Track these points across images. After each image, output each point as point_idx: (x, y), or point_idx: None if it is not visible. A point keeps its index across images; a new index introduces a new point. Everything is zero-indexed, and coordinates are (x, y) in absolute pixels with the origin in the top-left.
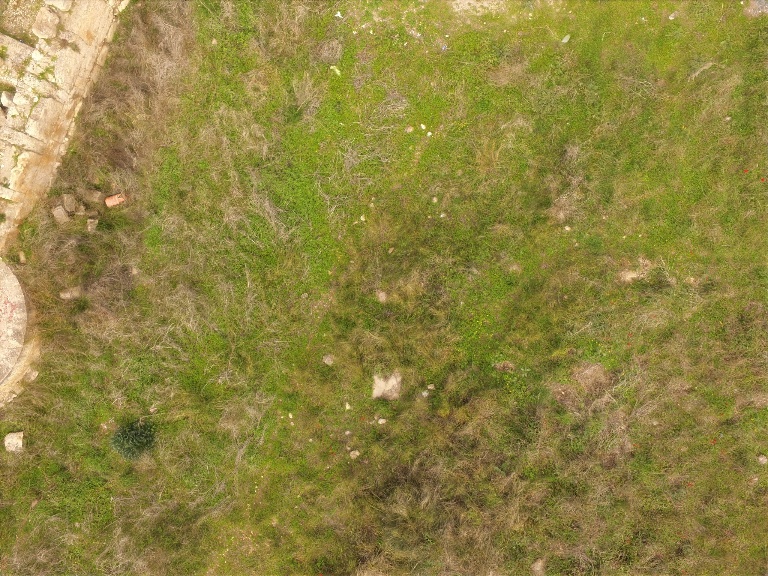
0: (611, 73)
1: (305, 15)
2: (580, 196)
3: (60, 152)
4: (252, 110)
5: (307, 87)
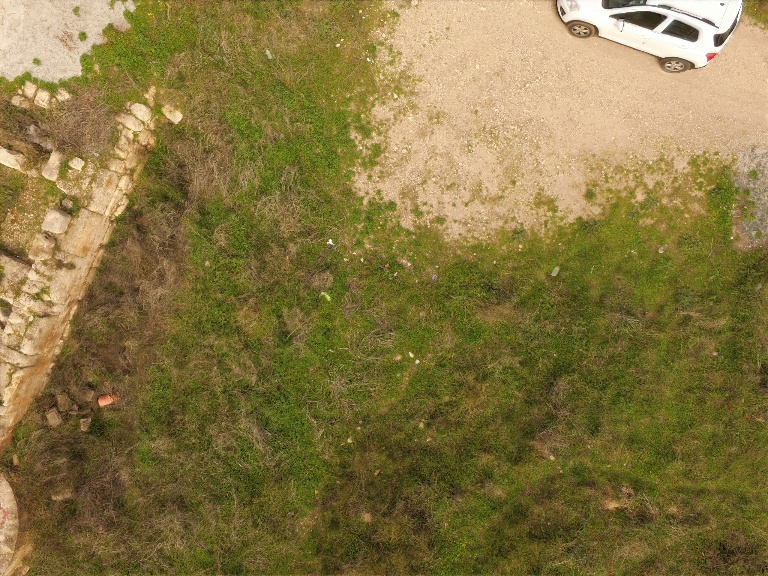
0: (599, 307)
1: (297, 248)
2: (565, 430)
3: (55, 353)
4: (243, 333)
5: (297, 318)
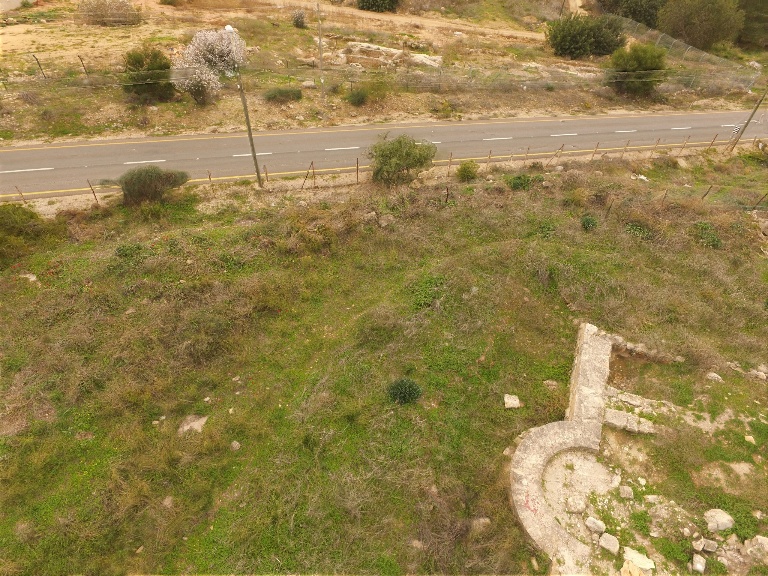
0: None
1: None
2: None
3: None
4: None
5: None
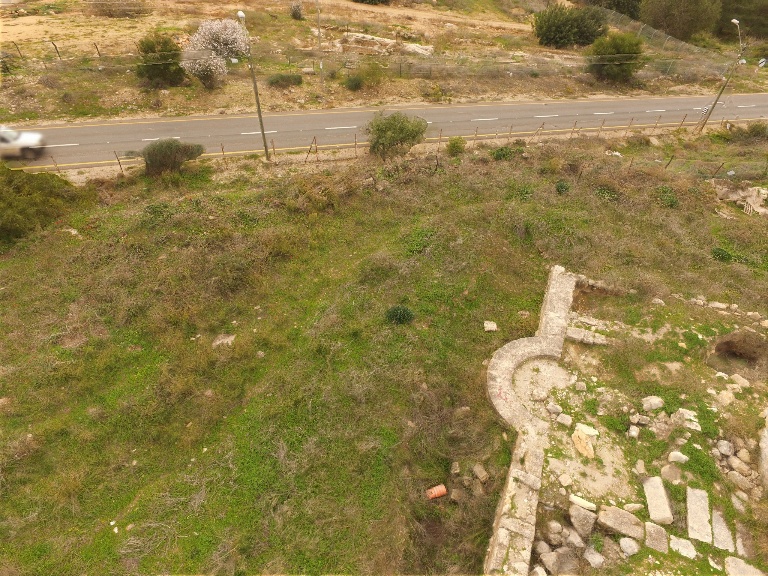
0: None
1: None
2: (2, 457)
3: None
4: (285, 554)
5: (218, 568)
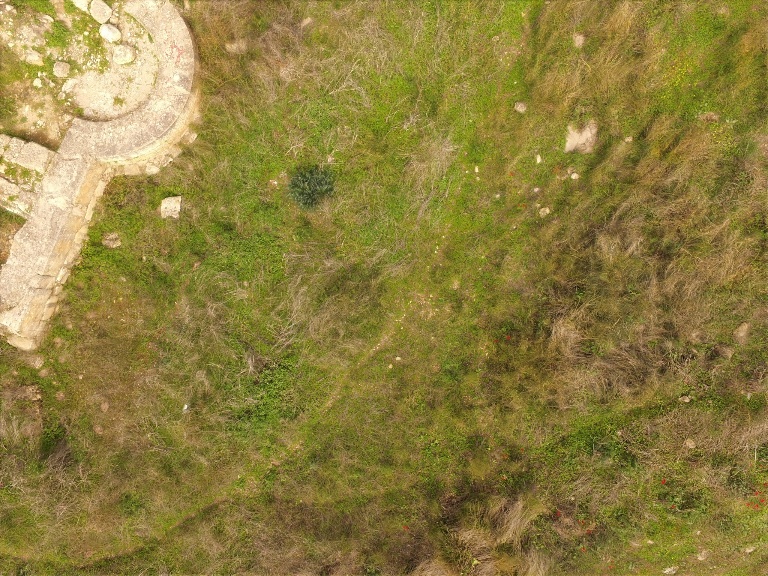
0: None
1: None
2: None
3: None
4: None
5: None
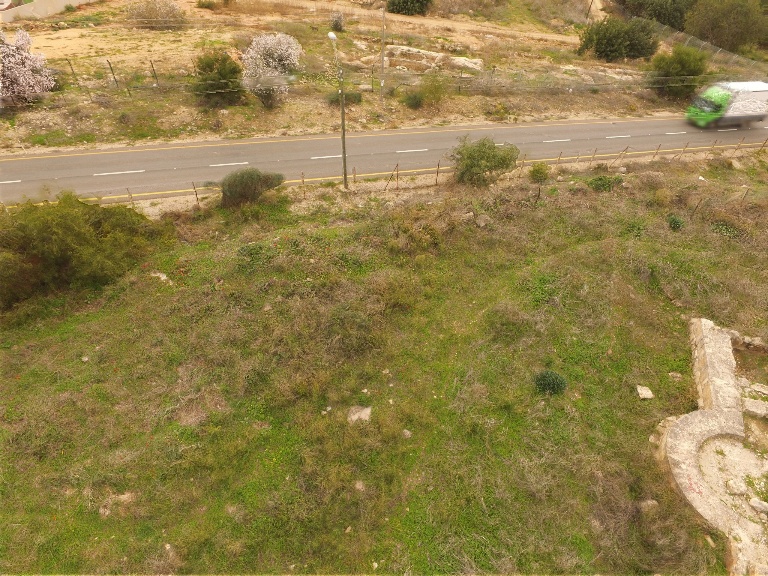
0: None
1: None
2: None
3: None
4: None
5: None
